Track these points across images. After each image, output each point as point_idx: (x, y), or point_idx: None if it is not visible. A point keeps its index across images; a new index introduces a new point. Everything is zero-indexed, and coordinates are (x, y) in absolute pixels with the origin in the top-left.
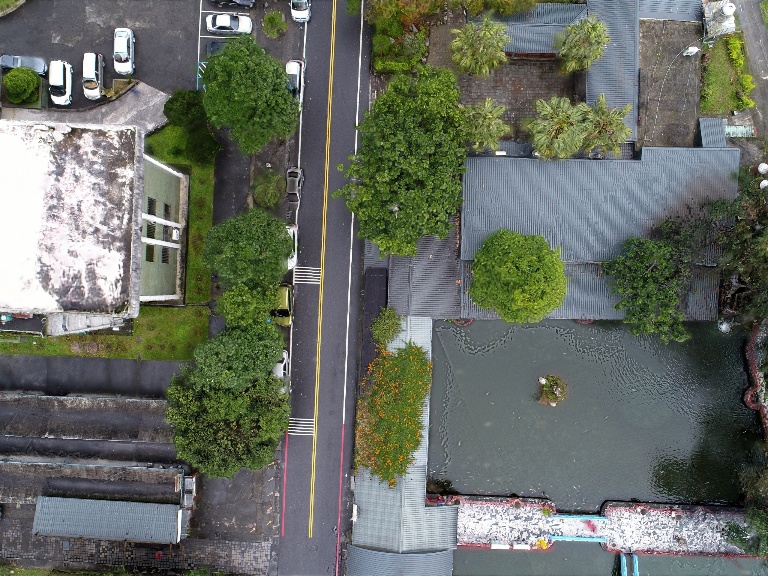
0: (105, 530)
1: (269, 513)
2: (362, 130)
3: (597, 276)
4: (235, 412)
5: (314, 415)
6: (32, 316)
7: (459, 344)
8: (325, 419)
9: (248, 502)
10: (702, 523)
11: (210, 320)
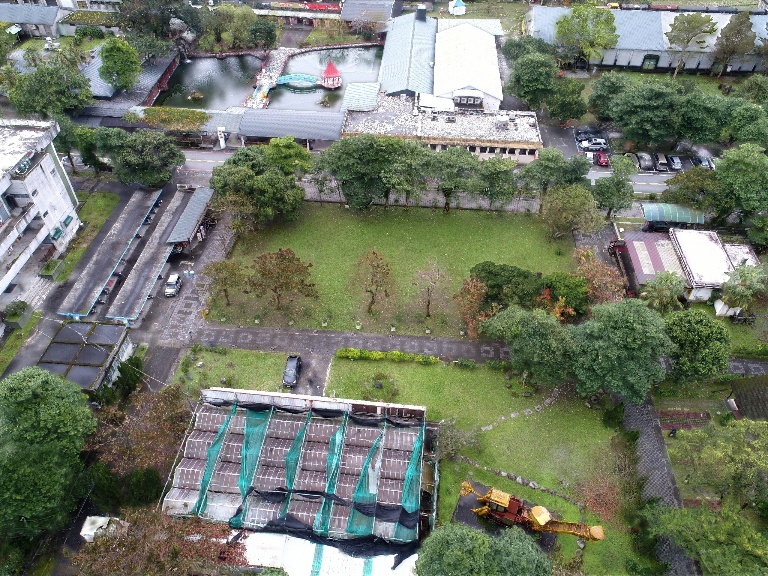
0: (198, 212)
1: None
2: (24, 99)
3: (142, 72)
4: None
5: None
6: (34, 154)
7: None
8: None
9: None
10: (270, 67)
11: None
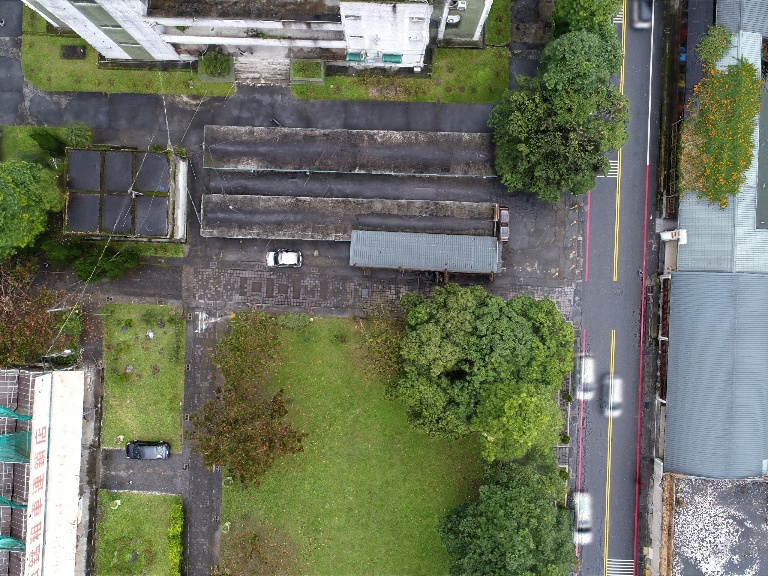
0: (423, 261)
1: (572, 257)
2: None
3: None
4: (584, 114)
5: (618, 156)
6: None
7: (763, 84)
8: (629, 160)
9: (551, 246)
10: None
11: (510, 61)
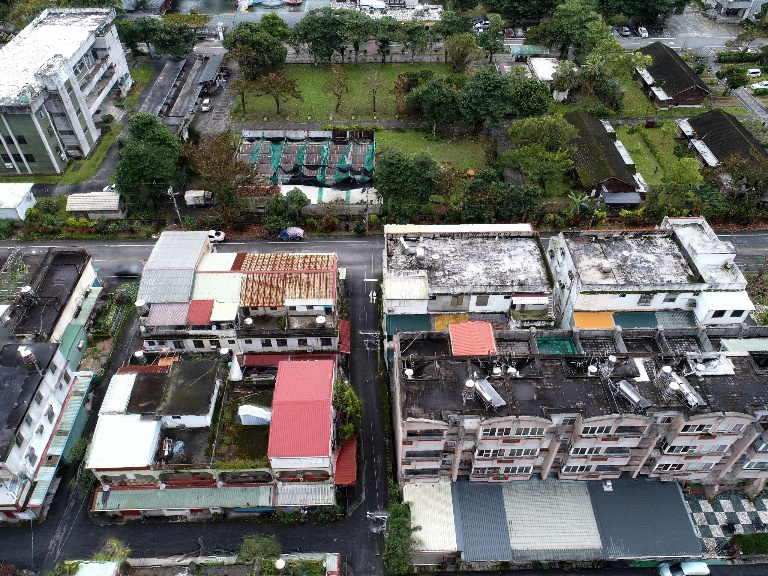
0: None
1: None
2: None
3: None
4: None
5: None
6: None
7: None
8: None
9: None
10: None
11: None
